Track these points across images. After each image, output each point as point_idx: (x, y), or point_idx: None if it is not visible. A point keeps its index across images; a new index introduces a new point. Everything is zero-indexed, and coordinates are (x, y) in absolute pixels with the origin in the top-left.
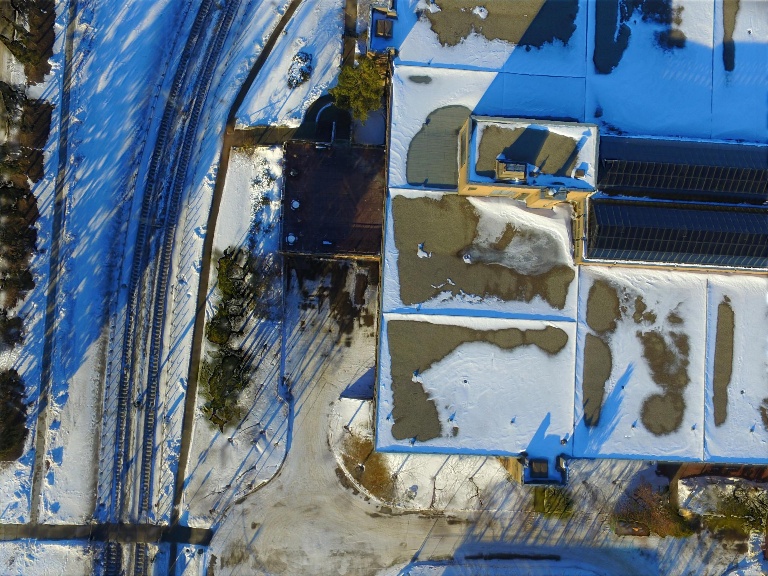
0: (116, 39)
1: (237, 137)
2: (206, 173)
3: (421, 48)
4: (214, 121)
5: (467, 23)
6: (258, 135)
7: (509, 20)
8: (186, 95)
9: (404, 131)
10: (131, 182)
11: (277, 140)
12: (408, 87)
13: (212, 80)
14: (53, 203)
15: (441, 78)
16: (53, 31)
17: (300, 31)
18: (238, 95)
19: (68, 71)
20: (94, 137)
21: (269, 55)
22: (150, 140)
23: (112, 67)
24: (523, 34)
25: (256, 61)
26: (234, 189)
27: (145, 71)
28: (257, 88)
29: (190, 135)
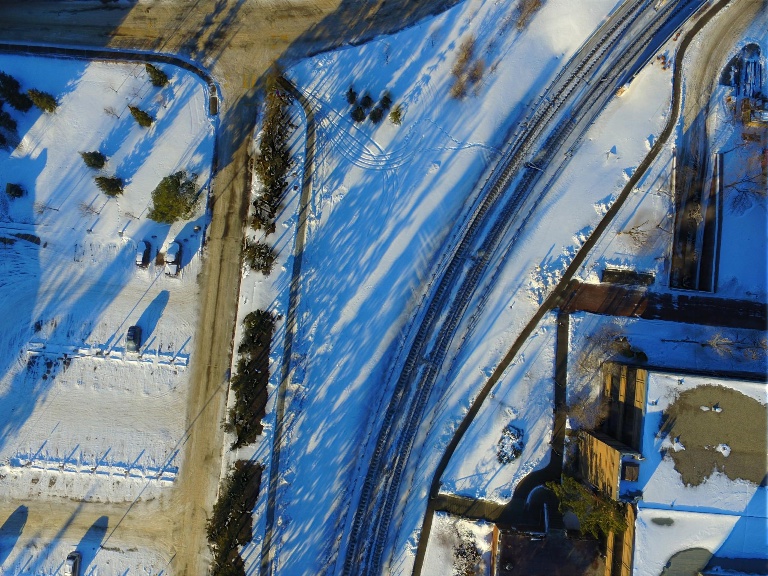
0: (327, 399)
1: (441, 502)
2: (408, 536)
3: (664, 489)
4: (418, 483)
5: (710, 462)
6: (465, 506)
7: (752, 459)
8: (390, 452)
9: (645, 575)
10: (335, 545)
11: (484, 514)
12: (650, 529)
13: (415, 437)
14: (259, 566)
15: (683, 520)
16: (266, 391)
17: (509, 398)
18: (443, 458)
19: (279, 431)
20: (301, 499)
21: (475, 417)
22: (354, 500)
23: (322, 428)
24: (765, 474)
25: (462, 423)
26: (437, 556)
27: (353, 432)
28: (462, 452)
29: (392, 493)
